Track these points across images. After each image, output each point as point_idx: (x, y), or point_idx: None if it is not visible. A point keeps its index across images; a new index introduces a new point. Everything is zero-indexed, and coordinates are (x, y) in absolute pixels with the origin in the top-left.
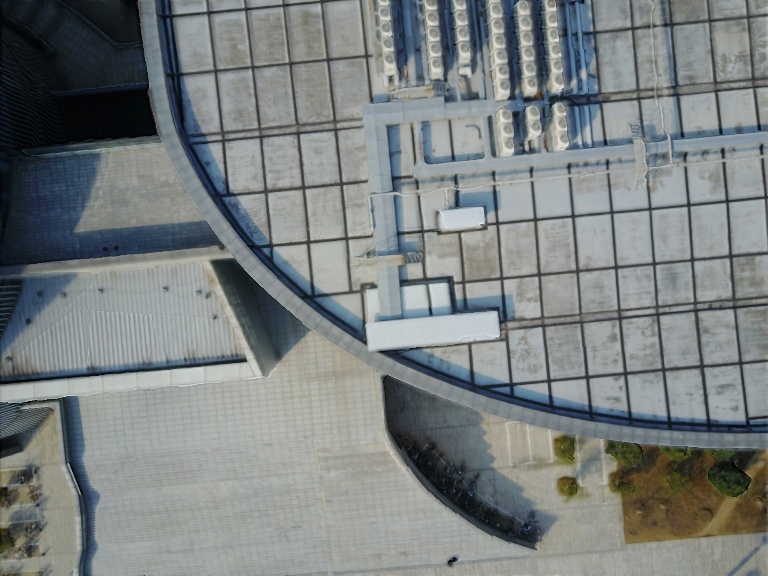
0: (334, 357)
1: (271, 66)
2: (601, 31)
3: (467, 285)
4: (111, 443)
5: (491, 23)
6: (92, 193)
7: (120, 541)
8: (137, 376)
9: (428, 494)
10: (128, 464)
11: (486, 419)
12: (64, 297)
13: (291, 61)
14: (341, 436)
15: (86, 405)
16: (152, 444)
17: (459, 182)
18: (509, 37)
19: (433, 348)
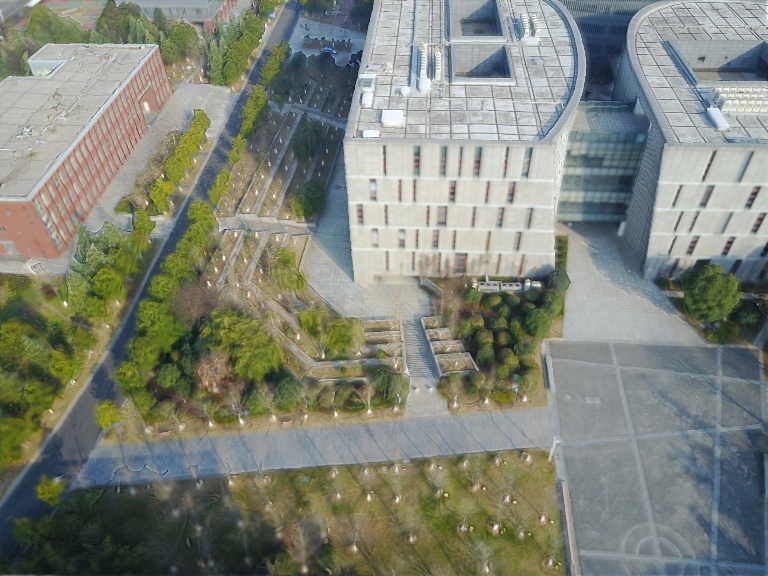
0: None
1: None
2: None
3: None
4: None
5: None
6: None
7: None
8: None
9: None
10: None
11: None
12: None
13: None
14: None
15: None
16: None
17: None
18: None
19: None
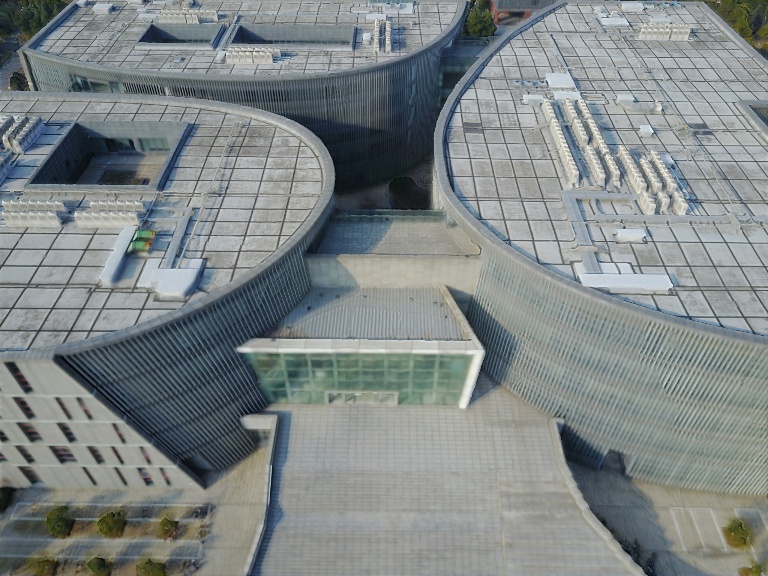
0: (513, 409)
1: (505, 177)
2: (689, 179)
3: (642, 267)
4: (311, 458)
5: (628, 164)
6: (378, 238)
7: (285, 575)
8: (386, 342)
9: (611, 537)
10: (322, 479)
11: (649, 503)
12: (338, 298)
13: (516, 176)
14: (522, 471)
15: (296, 426)
16: (348, 462)
17: (624, 224)
18: (640, 169)
19: (626, 295)
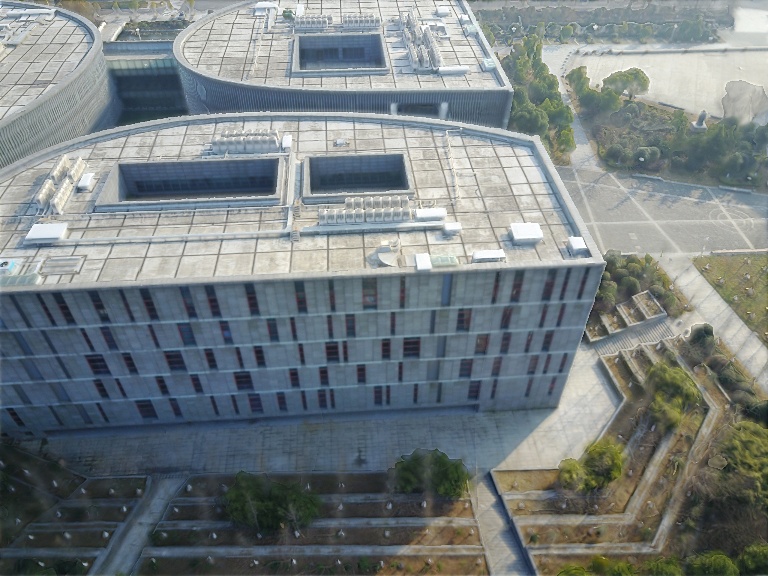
0: None
1: (49, 53)
2: None
3: (13, 21)
4: None
5: None
6: None
7: None
8: None
9: None
10: None
11: None
12: None
13: None
14: None
15: None
16: None
17: None
18: None
19: None
